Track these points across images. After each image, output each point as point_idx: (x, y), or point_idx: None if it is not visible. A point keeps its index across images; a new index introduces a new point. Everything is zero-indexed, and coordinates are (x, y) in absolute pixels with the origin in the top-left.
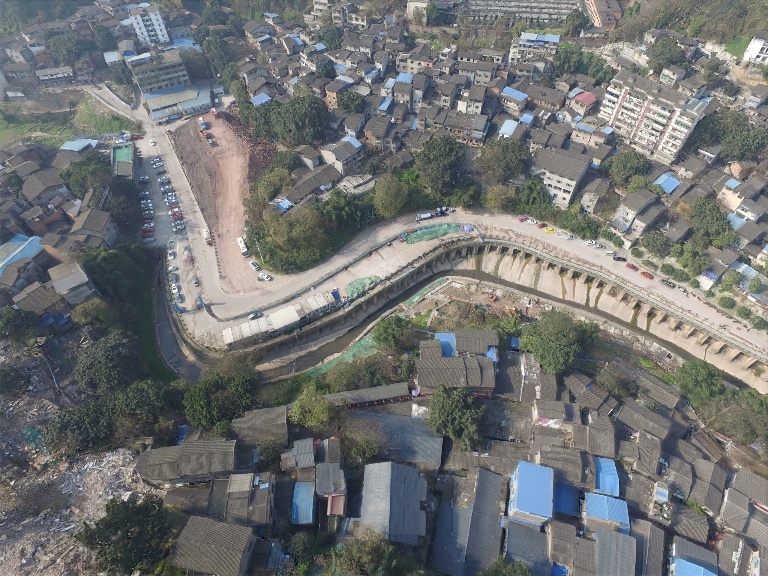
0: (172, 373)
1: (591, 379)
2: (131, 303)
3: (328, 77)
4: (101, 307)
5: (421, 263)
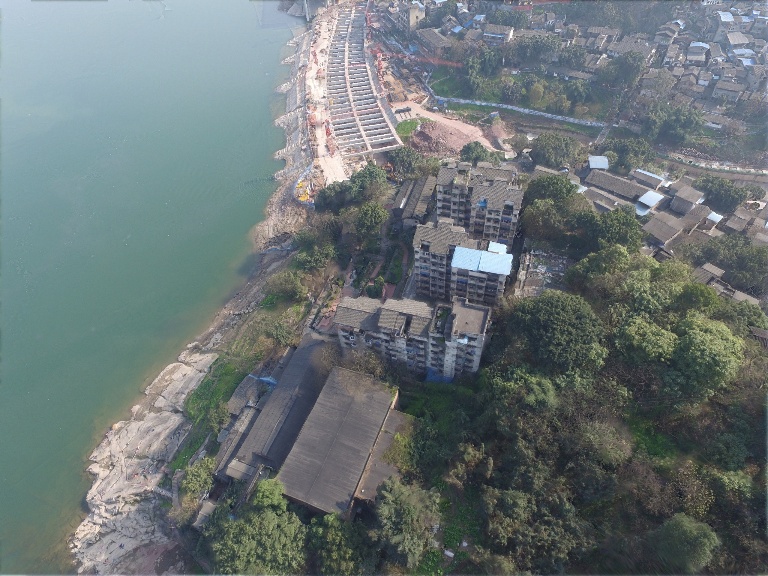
0: None
1: (761, 106)
2: None
3: None
4: None
5: None
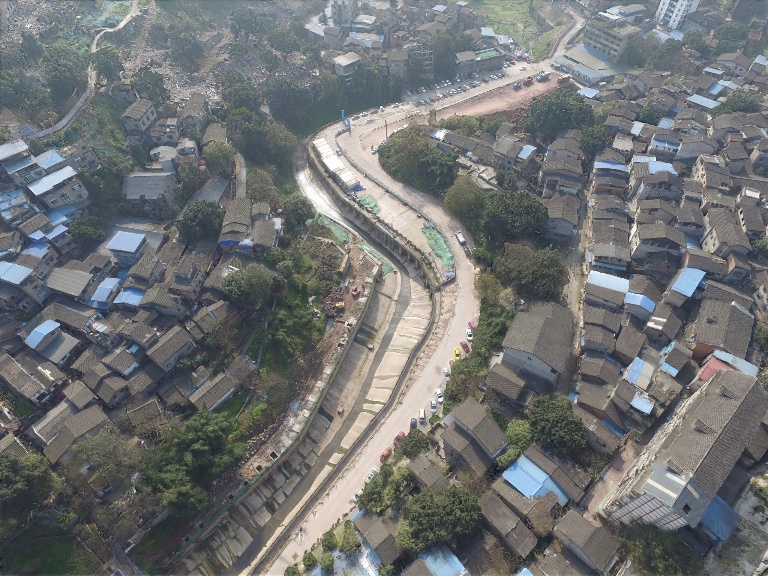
0: (306, 135)
1: None
2: (358, 105)
3: (648, 121)
4: (328, 79)
5: (400, 241)
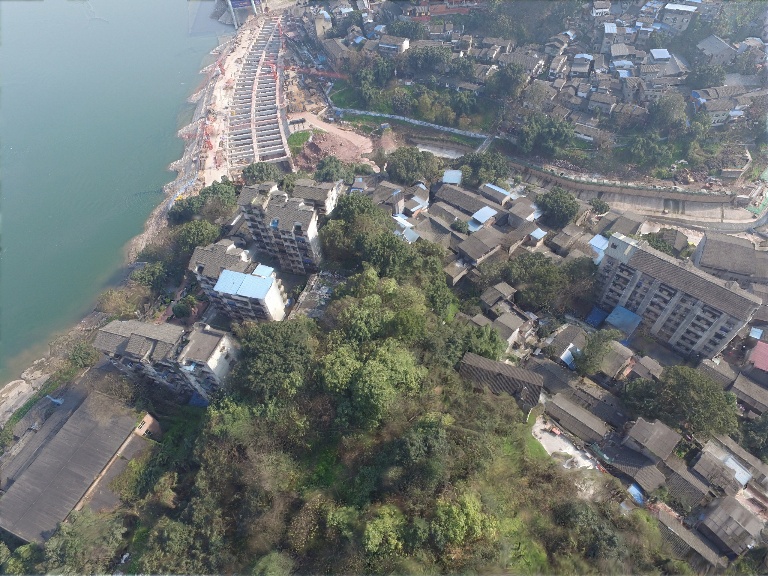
0: None
1: None
2: None
3: None
4: None
5: None
